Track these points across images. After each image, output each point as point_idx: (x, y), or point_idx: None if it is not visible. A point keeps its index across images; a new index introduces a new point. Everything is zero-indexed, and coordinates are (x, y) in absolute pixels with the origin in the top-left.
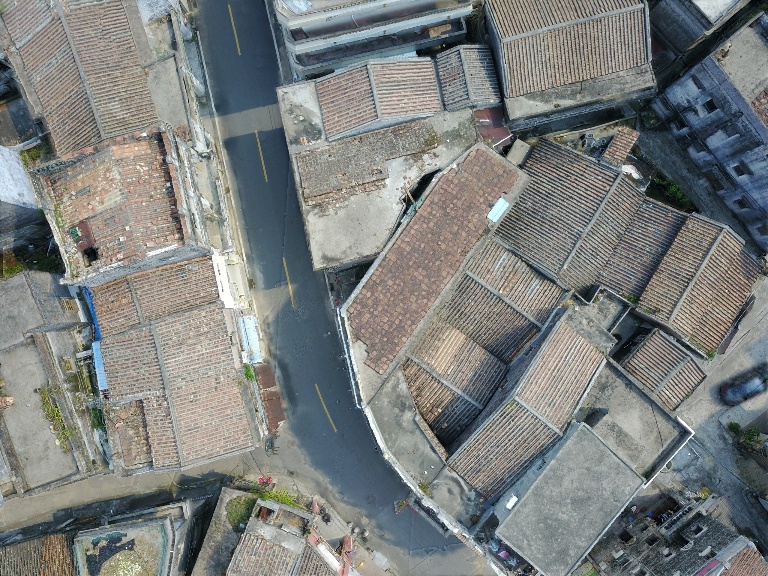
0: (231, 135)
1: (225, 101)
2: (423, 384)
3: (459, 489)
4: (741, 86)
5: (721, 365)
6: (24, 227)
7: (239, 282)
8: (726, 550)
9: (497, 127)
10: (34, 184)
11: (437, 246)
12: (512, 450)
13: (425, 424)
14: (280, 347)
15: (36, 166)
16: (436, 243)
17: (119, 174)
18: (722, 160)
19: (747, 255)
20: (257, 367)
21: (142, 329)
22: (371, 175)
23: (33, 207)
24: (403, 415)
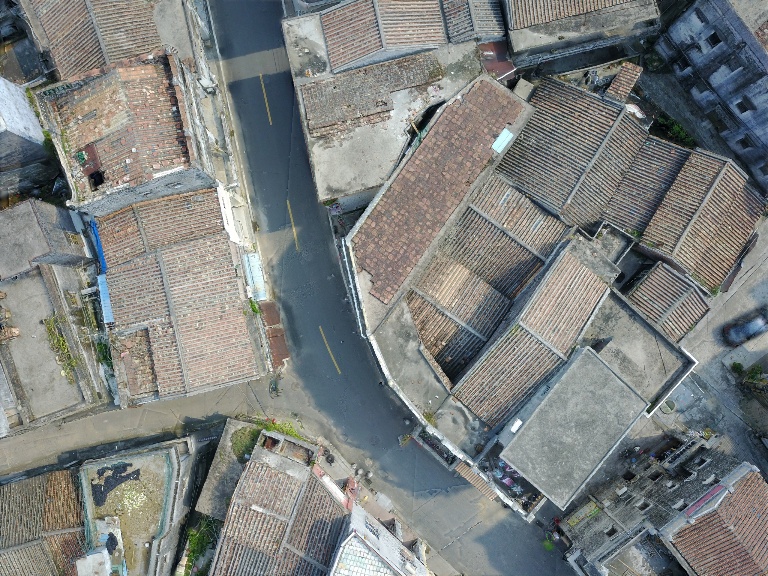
0: (235, 78)
1: (230, 45)
2: (427, 317)
3: (463, 418)
4: (744, 16)
5: (724, 306)
6: (29, 165)
7: (243, 225)
8: (730, 476)
9: (501, 61)
10: (41, 107)
11: (442, 176)
12: (516, 377)
13: (429, 354)
14: (284, 289)
15: (43, 90)
16: (441, 173)
17: (125, 96)
18: (725, 98)
19: (750, 191)
20: (262, 304)
21: (148, 256)
22: (376, 107)
23: (39, 143)
24: (408, 345)
